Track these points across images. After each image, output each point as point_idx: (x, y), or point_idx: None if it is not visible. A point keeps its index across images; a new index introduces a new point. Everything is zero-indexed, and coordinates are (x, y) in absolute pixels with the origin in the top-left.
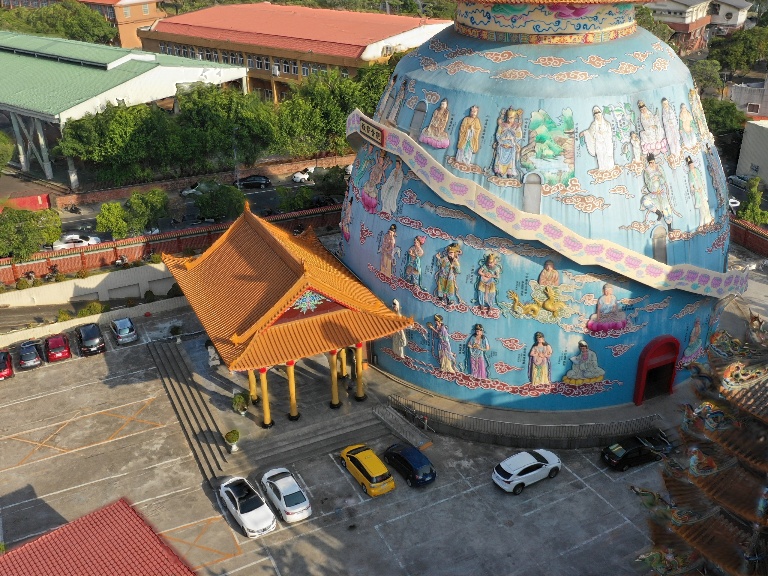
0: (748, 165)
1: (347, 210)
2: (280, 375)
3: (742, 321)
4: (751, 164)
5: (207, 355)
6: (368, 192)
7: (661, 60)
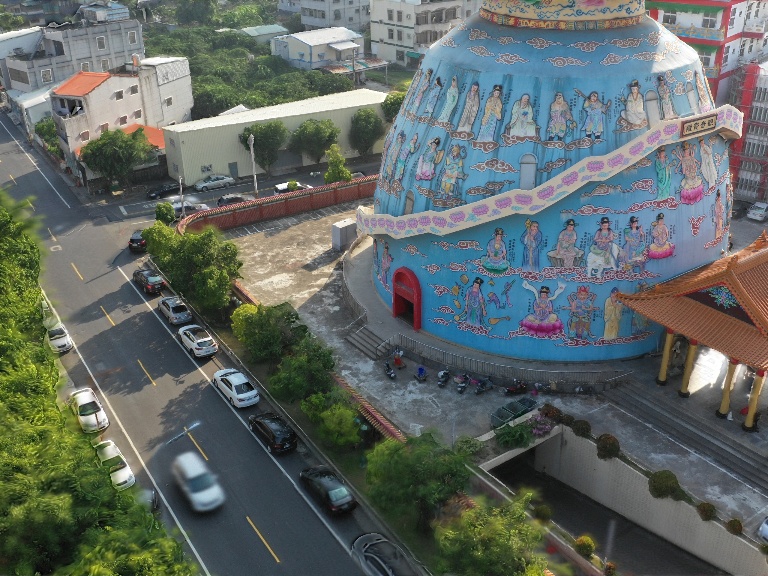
0: (199, 170)
1: (660, 230)
2: (767, 375)
3: None
4: (202, 167)
5: None
6: (693, 186)
7: None
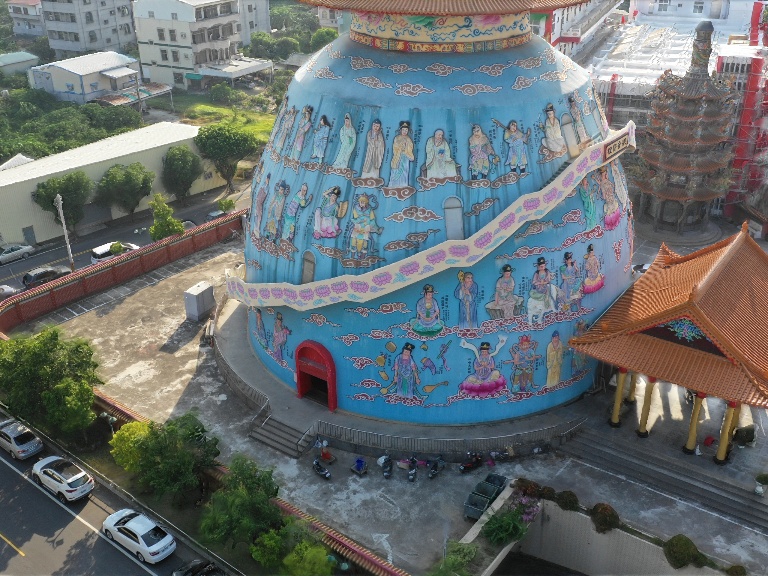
0: None
1: (592, 263)
2: None
3: None
4: None
5: (747, 456)
6: None
7: None
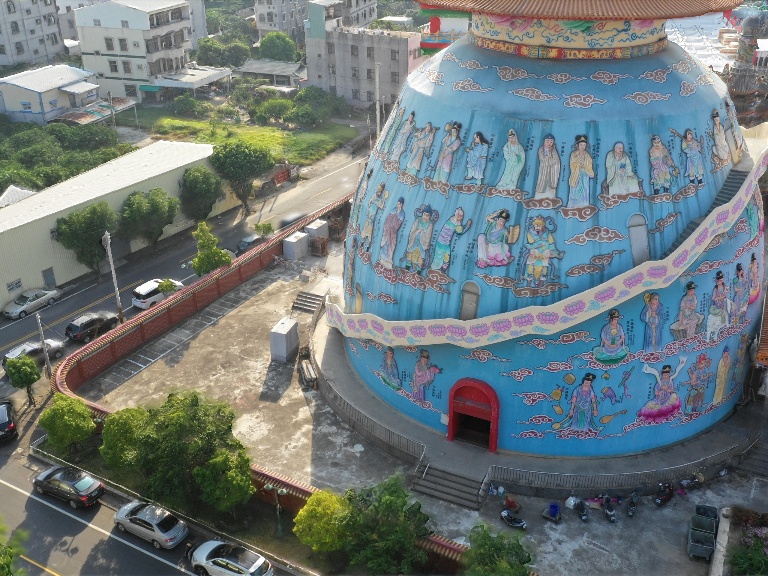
0: (4, 290)
1: None
2: None
3: None
4: (8, 285)
5: None
6: None
7: None
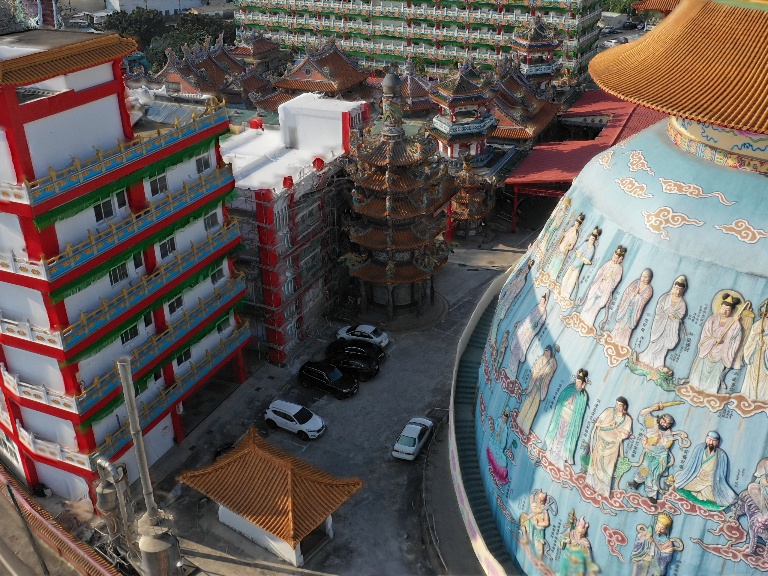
0: None
1: None
2: None
3: (451, 569)
4: None
5: None
6: None
7: (610, 154)
